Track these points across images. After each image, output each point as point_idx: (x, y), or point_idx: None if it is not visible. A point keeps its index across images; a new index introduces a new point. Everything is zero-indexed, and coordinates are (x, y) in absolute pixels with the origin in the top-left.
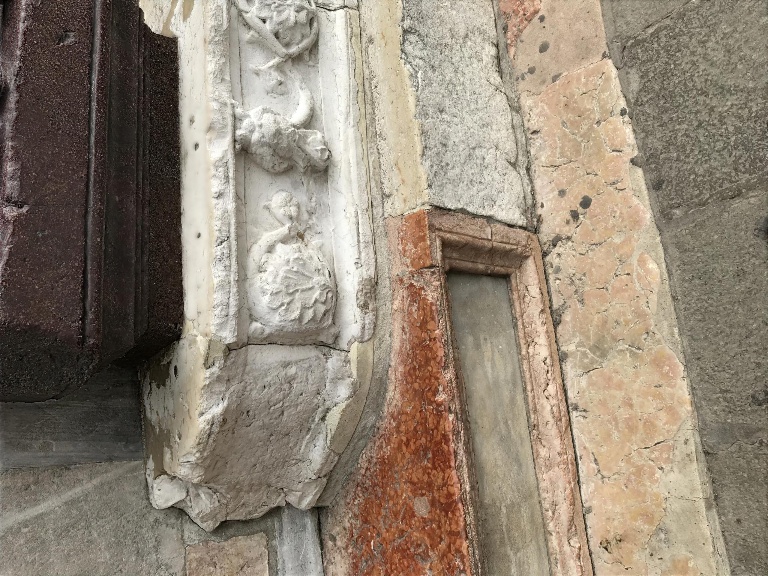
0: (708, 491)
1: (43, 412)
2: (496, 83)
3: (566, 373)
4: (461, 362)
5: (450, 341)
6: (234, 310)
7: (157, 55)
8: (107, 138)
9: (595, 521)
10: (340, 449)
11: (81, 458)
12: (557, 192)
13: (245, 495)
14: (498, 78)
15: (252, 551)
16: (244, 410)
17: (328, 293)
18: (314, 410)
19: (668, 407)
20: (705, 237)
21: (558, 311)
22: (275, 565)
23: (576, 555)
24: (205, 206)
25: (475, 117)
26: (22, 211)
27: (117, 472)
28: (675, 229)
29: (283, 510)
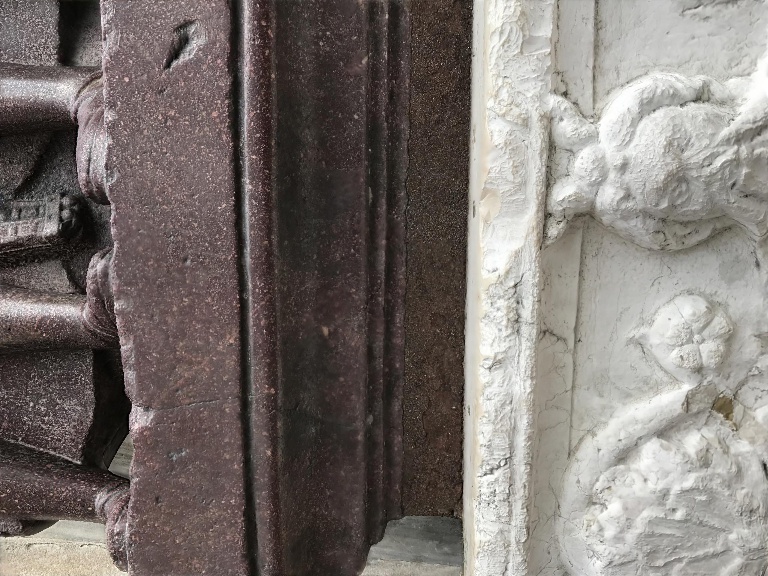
0: None
1: None
2: None
3: None
4: None
5: None
6: None
7: None
8: (281, 241)
9: None
10: None
11: (382, 554)
12: None
13: None
14: None
15: None
16: None
17: None
18: None
19: None
20: None
21: None
22: None
23: None
24: None
25: None
26: (146, 420)
27: (427, 575)
28: None
29: None
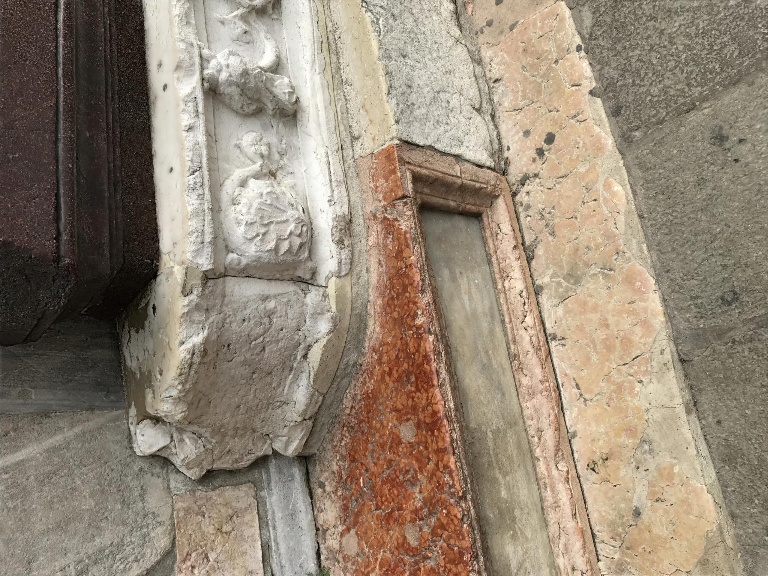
0: (687, 397)
1: (21, 360)
2: (456, 35)
3: (543, 305)
4: (438, 293)
5: (426, 267)
6: (209, 237)
7: (122, 7)
8: (75, 73)
9: (581, 444)
10: (324, 388)
11: (61, 406)
12: (522, 133)
13: (231, 440)
14: (458, 31)
15: (241, 501)
16: (225, 343)
17: (303, 227)
18: (295, 347)
19: (643, 321)
20: (665, 154)
21: (531, 247)
22: (265, 515)
23: (565, 478)
24: (176, 140)
25: (437, 64)
26: None
27: (99, 421)
28: (636, 151)
29: (270, 460)
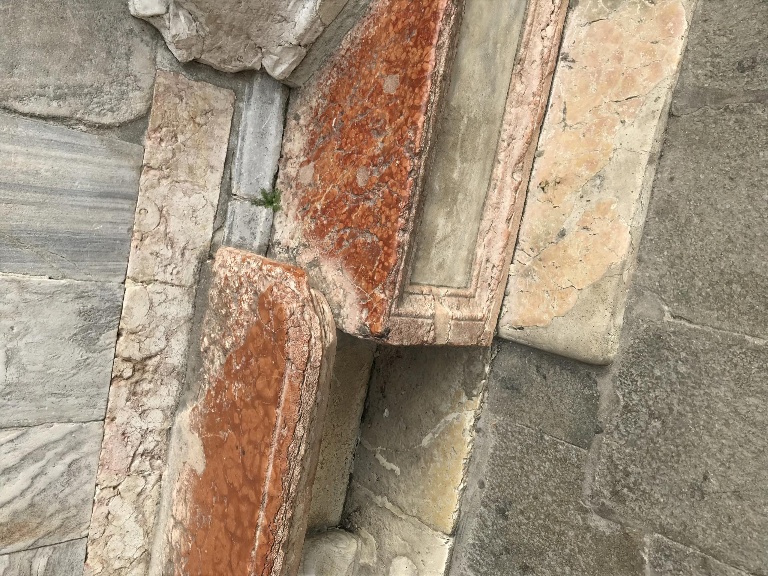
0: (657, 149)
1: None
2: None
3: (570, 21)
4: None
5: None
6: None
7: None
8: None
9: (543, 164)
10: (327, 19)
11: None
12: None
13: (224, 37)
14: None
15: (219, 102)
16: None
17: None
18: None
19: (655, 64)
20: None
21: None
22: (238, 125)
23: (515, 187)
24: None
25: None
26: None
27: None
28: None
29: (256, 77)
